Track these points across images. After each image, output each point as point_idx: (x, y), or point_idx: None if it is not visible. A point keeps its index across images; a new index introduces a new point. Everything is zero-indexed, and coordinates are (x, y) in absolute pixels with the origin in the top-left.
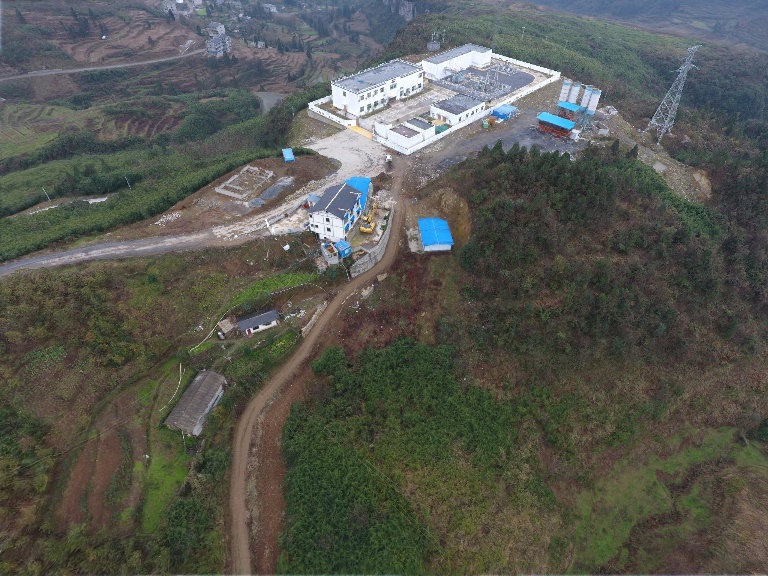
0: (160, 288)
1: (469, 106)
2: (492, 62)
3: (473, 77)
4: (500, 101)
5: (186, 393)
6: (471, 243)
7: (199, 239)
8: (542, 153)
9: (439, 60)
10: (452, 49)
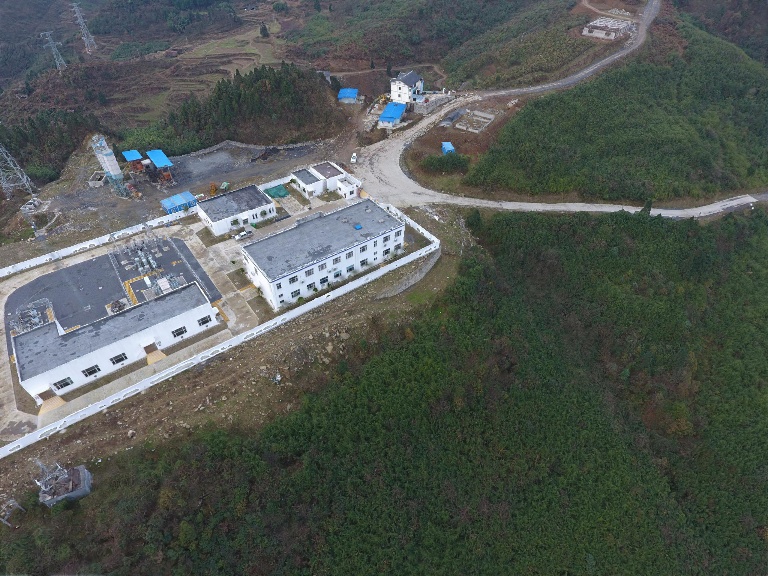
0: (494, 82)
1: (225, 199)
2: (14, 366)
3: (126, 302)
4: (155, 233)
5: (471, 88)
6: (334, 79)
7: (487, 94)
8: (248, 93)
9: (174, 303)
10: (102, 348)
